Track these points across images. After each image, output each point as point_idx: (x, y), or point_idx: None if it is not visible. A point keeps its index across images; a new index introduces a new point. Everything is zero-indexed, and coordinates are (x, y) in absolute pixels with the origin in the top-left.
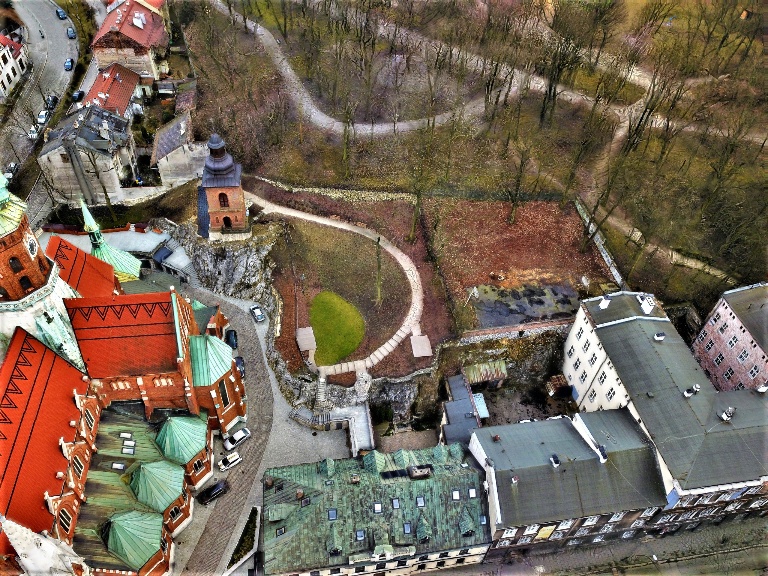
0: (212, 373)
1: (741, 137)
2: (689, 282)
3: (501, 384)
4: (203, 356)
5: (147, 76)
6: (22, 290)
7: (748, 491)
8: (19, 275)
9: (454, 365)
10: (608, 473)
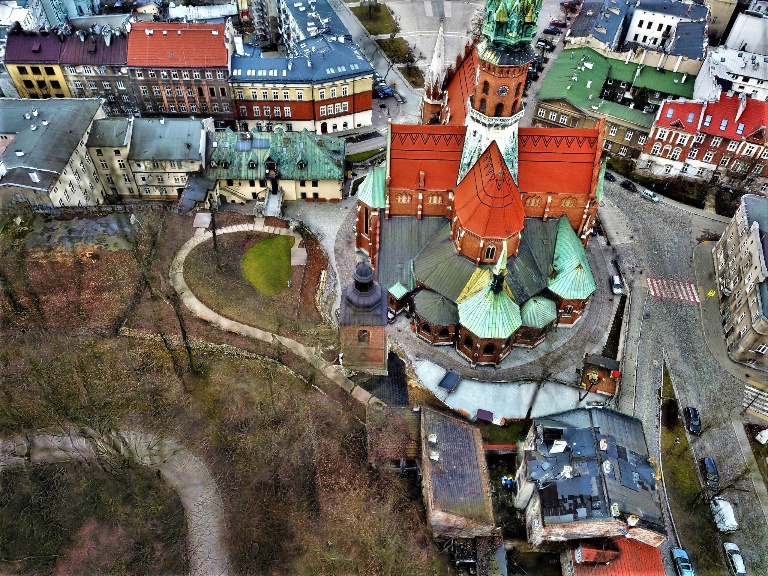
0: None
1: None
2: None
3: None
4: None
5: None
6: None
7: None
8: None
9: None
10: None
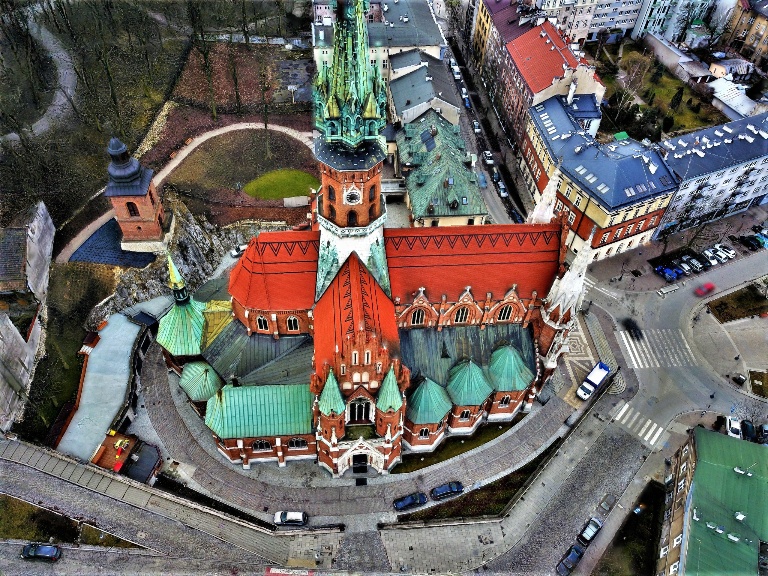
0: None
1: None
2: None
3: None
4: None
5: None
6: None
7: None
8: None
9: None
10: (432, 68)
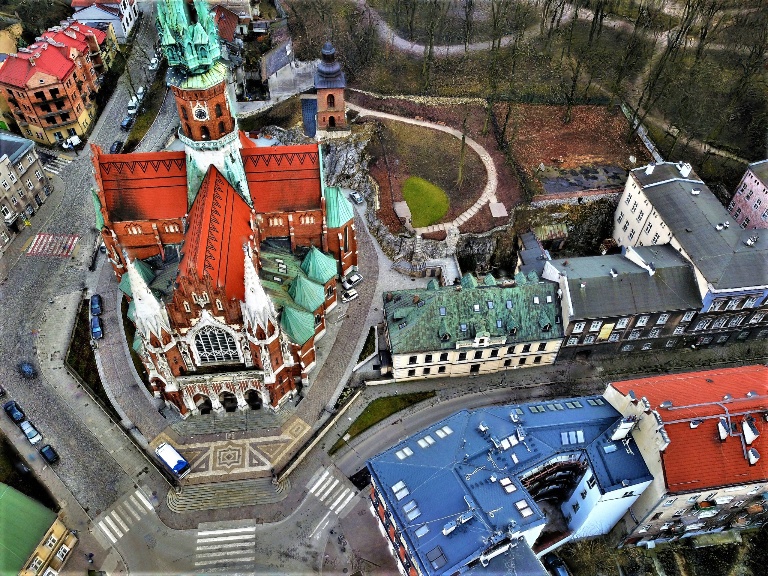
0: (341, 218)
1: (766, 45)
2: (720, 167)
3: (562, 245)
4: (334, 203)
5: (244, 17)
6: (219, 133)
7: (767, 300)
8: (219, 119)
9: (525, 226)
10: (656, 283)
